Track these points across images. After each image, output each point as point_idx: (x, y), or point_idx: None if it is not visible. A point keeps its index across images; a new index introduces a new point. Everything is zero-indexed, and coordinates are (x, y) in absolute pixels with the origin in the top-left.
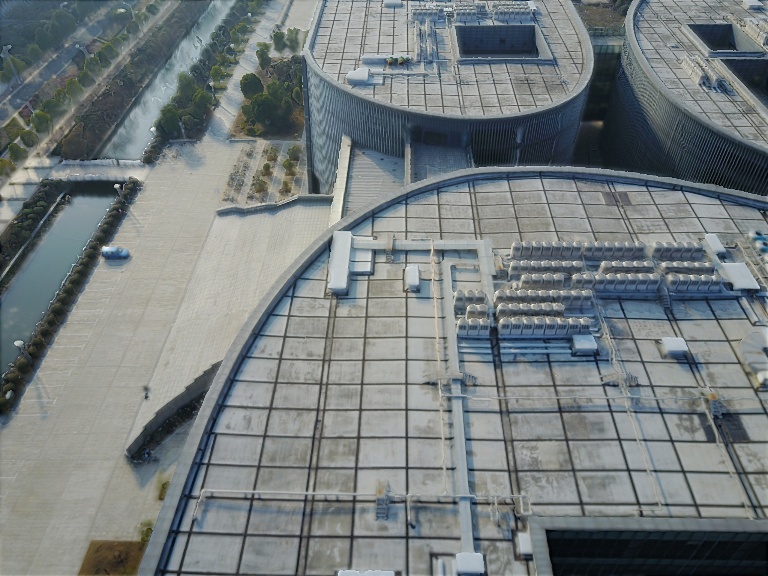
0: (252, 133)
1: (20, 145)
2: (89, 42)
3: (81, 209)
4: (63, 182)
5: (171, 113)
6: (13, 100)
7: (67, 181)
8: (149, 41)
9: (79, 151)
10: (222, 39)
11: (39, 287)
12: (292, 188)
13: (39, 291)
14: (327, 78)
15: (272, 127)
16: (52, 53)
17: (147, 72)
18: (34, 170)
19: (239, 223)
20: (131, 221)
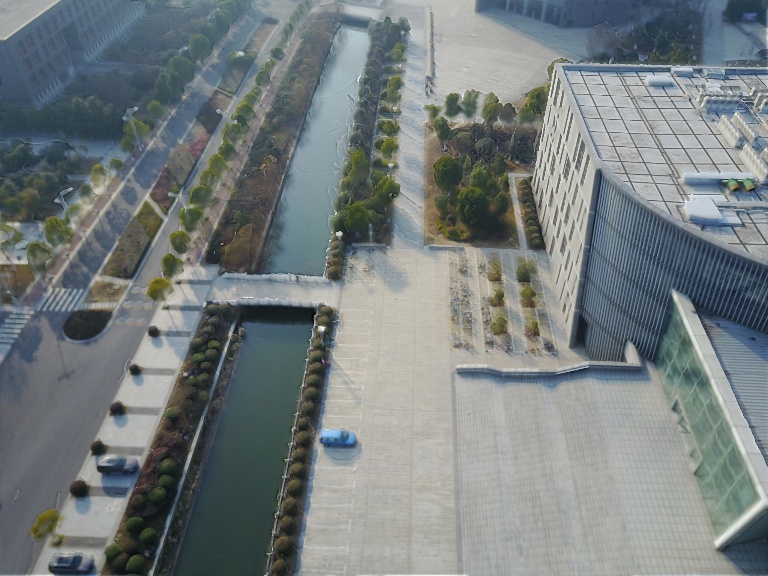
0: (455, 236)
1: (166, 248)
2: (211, 94)
3: (257, 346)
4: (233, 308)
5: (360, 212)
6: (138, 175)
7: (236, 305)
8: (285, 96)
9: (243, 259)
10: (370, 95)
11: (234, 485)
12: (540, 328)
13: (236, 493)
14: (663, 214)
15: (480, 229)
16: (170, 108)
17: (289, 137)
18: (189, 286)
19: (499, 394)
20: (340, 378)
